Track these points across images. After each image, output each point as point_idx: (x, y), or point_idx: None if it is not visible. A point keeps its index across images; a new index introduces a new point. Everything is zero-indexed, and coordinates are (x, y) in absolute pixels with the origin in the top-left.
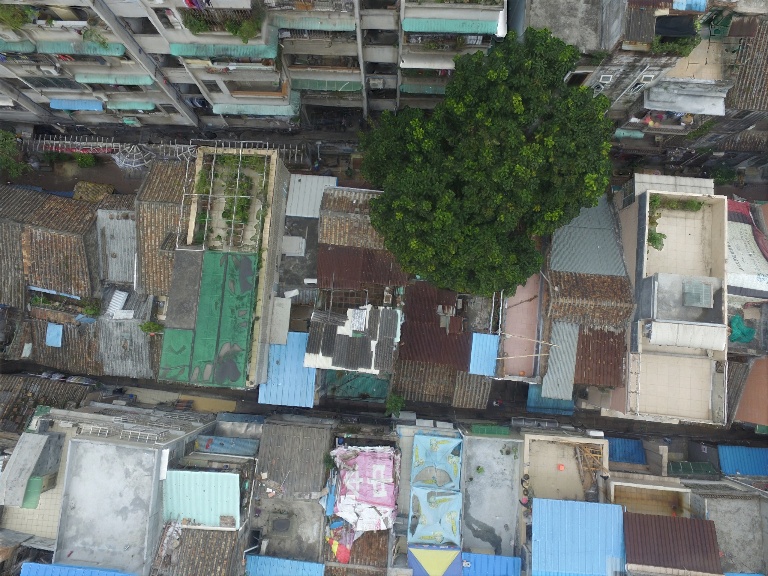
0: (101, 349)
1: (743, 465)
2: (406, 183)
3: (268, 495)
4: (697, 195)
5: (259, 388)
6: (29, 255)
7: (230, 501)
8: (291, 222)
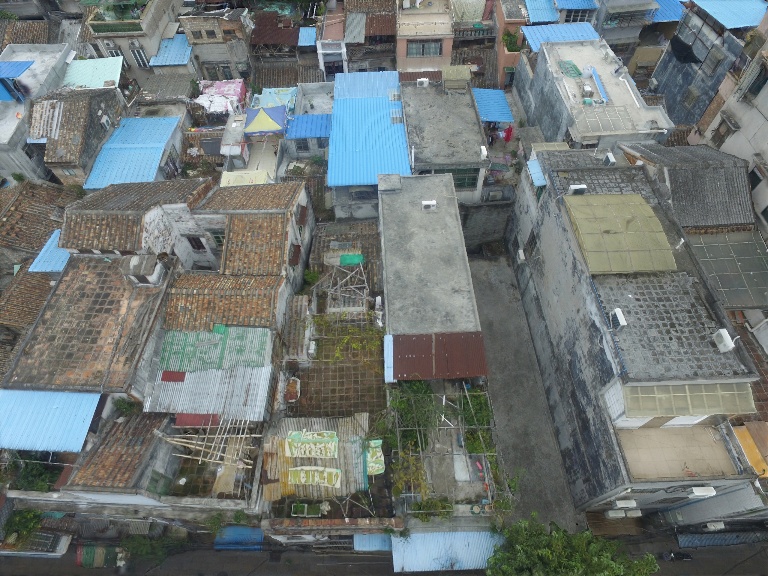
0: None
1: None
2: None
3: (146, 99)
4: None
5: (151, 58)
6: (9, 37)
7: (114, 72)
8: (187, 5)
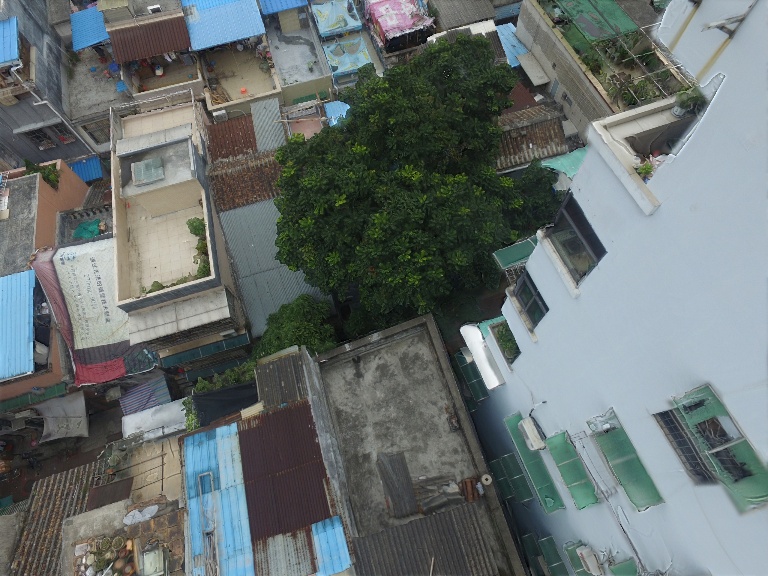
0: (662, 51)
1: (80, 169)
2: (493, 67)
3: None
4: (153, 293)
5: None
6: None
7: None
8: None
